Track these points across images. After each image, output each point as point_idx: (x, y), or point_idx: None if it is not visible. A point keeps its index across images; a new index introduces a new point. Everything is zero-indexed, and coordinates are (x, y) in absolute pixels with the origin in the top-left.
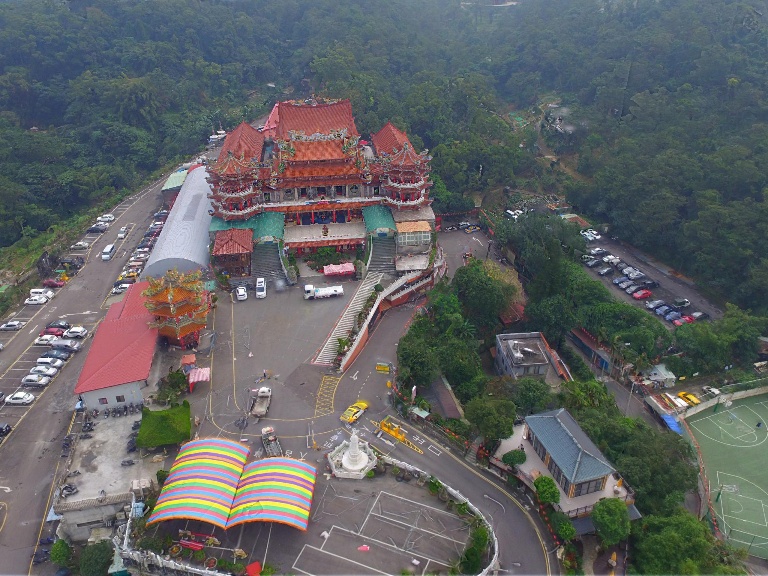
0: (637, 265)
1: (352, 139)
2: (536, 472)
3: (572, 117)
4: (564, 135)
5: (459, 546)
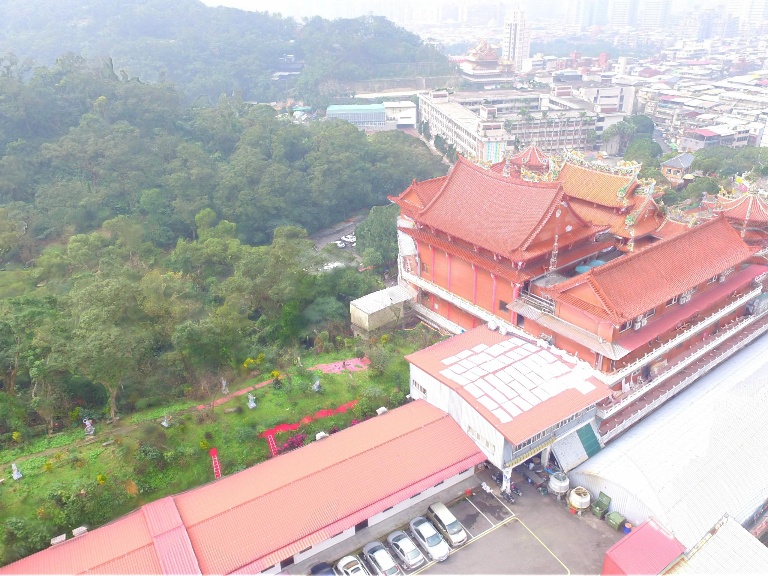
0: (348, 232)
1: (557, 163)
2: (699, 173)
3: (70, 201)
4: (5, 256)
5: (762, 179)
